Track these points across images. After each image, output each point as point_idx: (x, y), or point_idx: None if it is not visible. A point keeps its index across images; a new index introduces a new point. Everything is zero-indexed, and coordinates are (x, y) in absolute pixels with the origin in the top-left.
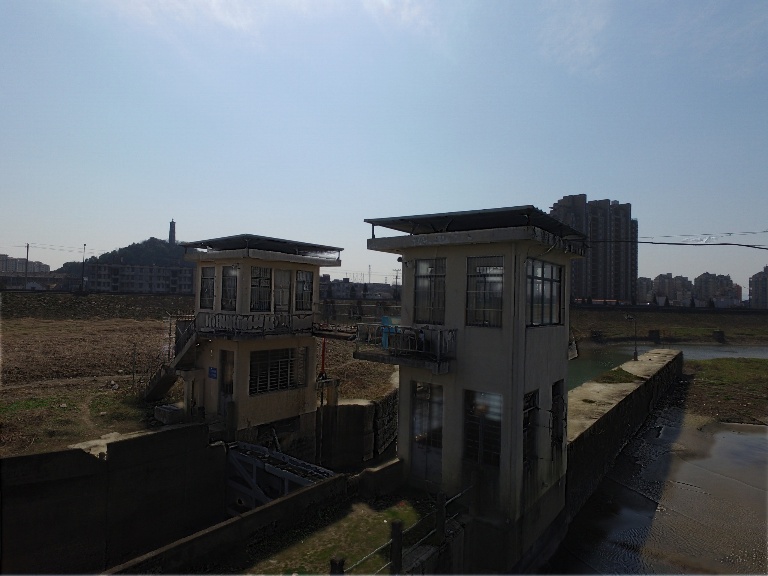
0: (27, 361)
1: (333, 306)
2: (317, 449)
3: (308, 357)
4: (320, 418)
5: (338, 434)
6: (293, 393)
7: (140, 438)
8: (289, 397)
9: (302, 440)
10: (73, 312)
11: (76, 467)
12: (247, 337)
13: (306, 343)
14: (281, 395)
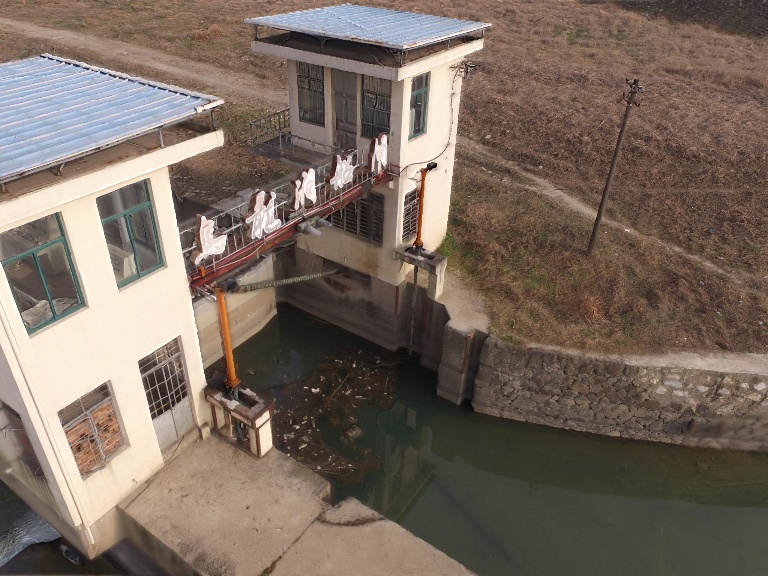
0: (468, 96)
1: (372, 148)
2: (409, 333)
3: (384, 210)
4: (412, 299)
5: (434, 337)
6: (361, 244)
7: (198, 204)
8: (355, 246)
9: (375, 306)
10: (762, 22)
11: (175, 203)
12: (262, 152)
13: (380, 189)
14: (344, 238)
